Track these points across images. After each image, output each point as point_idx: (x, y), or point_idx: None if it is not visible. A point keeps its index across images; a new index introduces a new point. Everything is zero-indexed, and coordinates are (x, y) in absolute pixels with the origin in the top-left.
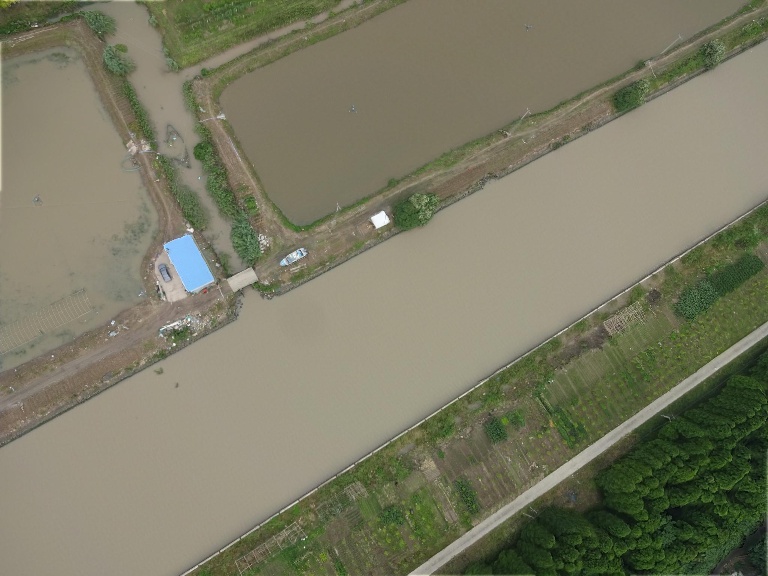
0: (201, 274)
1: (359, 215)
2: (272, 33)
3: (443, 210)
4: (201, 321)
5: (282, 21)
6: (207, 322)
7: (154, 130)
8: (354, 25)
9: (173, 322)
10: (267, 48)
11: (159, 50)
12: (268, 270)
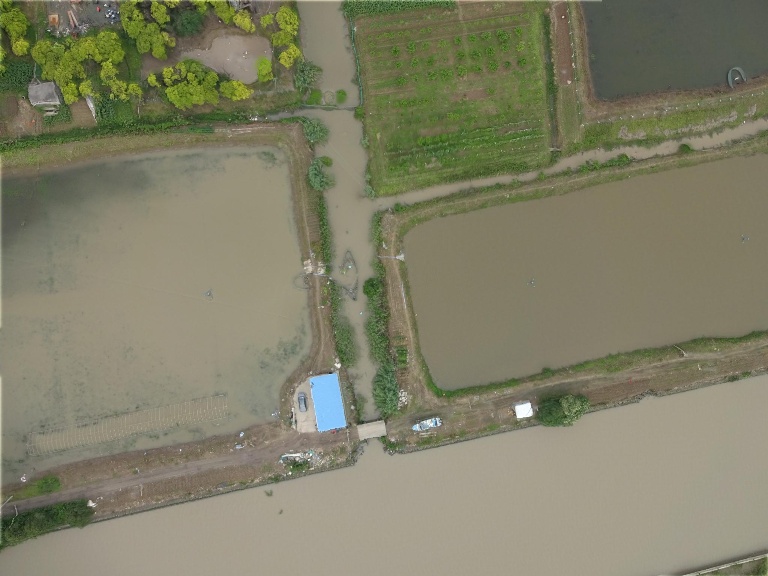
0: (336, 417)
1: (504, 397)
2: (476, 181)
3: (590, 414)
4: (321, 459)
5: (490, 172)
6: (326, 461)
7: (333, 253)
8: (561, 193)
9: (296, 452)
10: (466, 198)
11: (362, 172)
12: (399, 428)
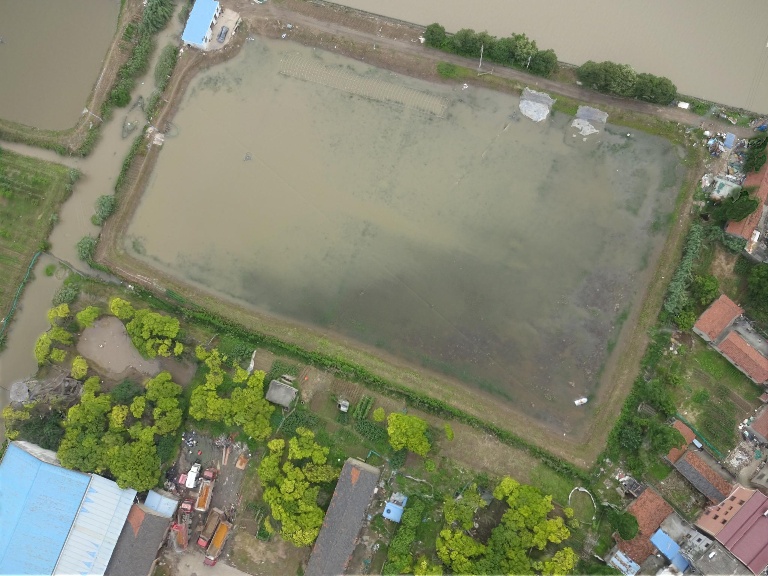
0: (201, 6)
1: None
2: None
3: None
4: None
5: None
6: None
7: None
8: None
9: (250, 0)
10: (5, 131)
11: None
12: None
